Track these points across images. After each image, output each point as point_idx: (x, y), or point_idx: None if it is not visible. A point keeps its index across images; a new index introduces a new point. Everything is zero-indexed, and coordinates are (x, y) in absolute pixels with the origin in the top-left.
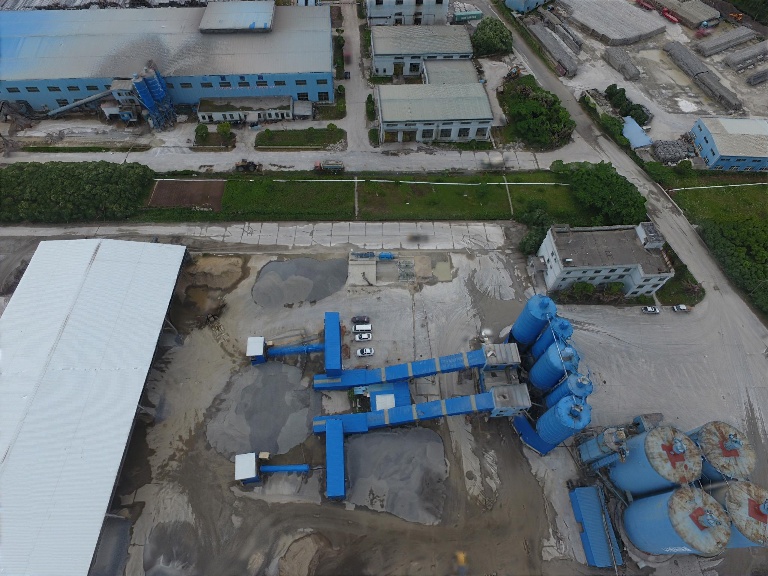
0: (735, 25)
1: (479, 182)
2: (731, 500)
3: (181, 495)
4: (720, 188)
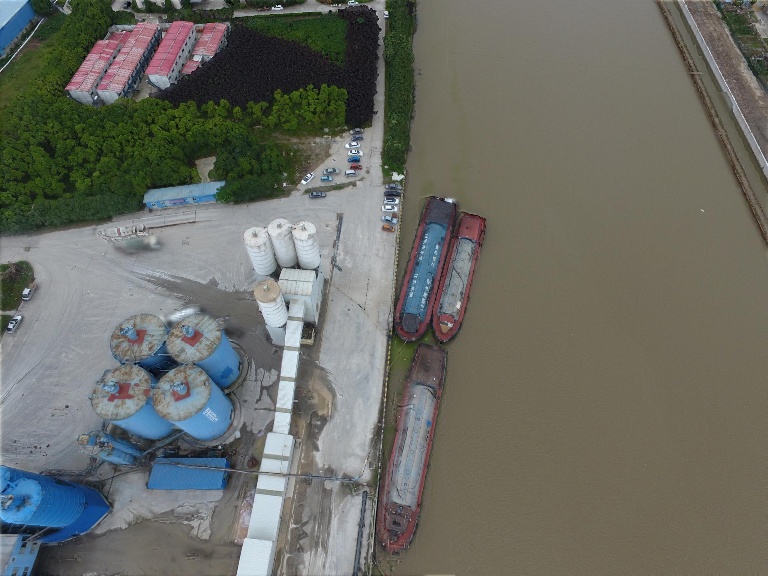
0: None
1: None
2: (178, 355)
3: None
4: None
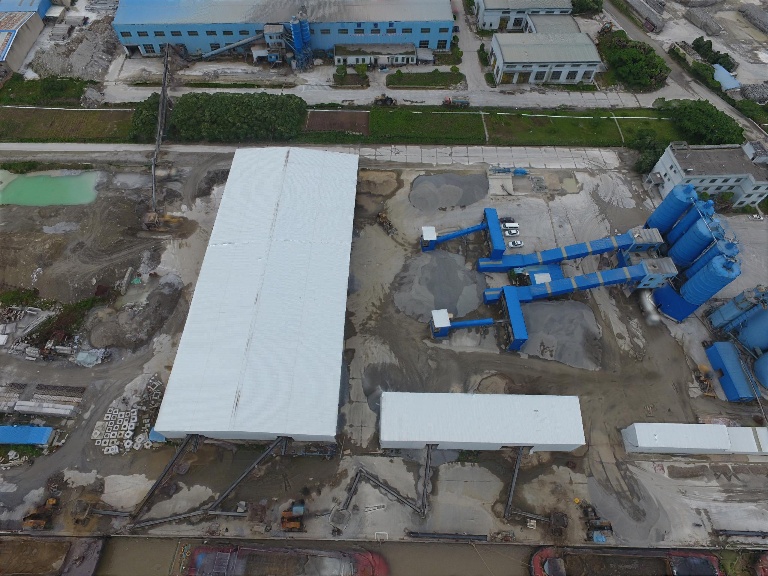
0: None
1: (591, 116)
2: None
3: (383, 345)
4: None
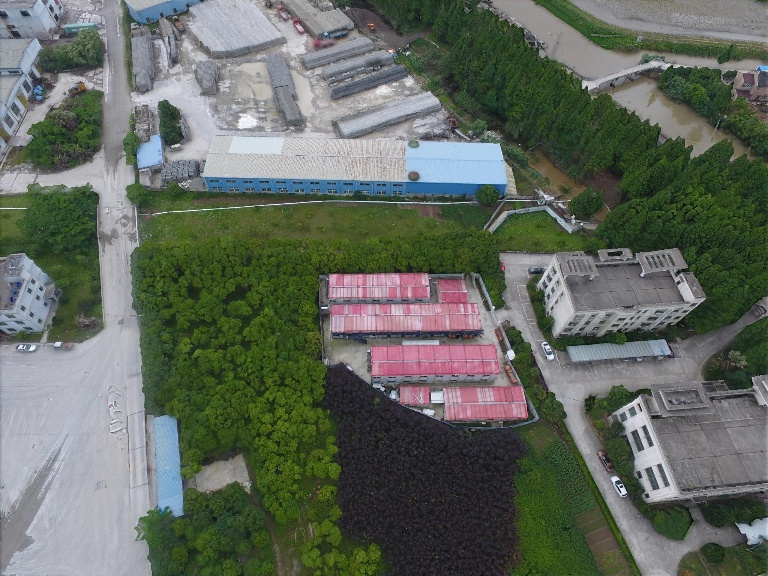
0: (365, 35)
1: None
2: None
3: None
4: (208, 211)
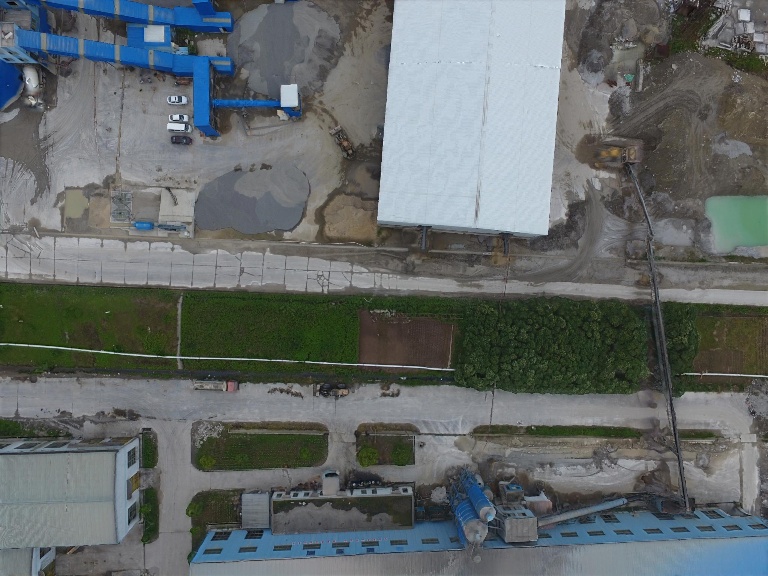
0: None
1: None
2: None
3: None
4: None
